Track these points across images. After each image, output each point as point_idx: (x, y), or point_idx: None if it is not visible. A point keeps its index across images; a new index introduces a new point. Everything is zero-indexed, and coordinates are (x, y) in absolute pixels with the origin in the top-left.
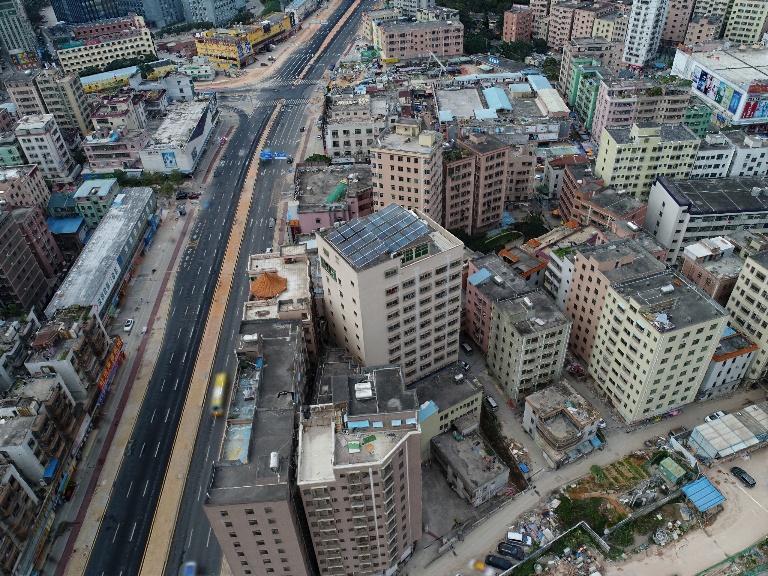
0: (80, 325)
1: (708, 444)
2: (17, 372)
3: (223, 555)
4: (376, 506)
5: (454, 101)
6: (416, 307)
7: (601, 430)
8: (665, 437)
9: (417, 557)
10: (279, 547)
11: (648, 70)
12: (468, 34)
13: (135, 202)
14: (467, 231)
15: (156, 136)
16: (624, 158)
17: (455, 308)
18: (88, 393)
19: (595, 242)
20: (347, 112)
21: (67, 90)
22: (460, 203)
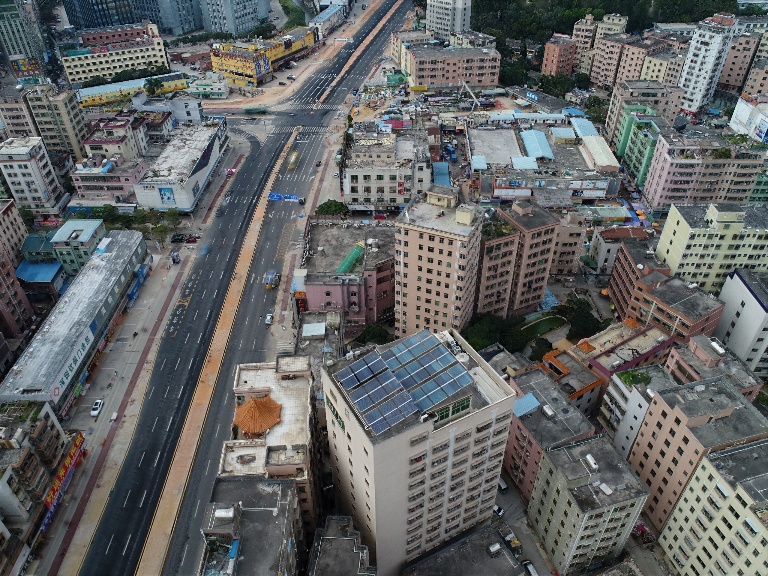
0: (27, 429)
1: None
2: None
3: None
4: None
5: (488, 143)
6: (447, 470)
7: None
8: None
9: None
10: None
11: (702, 116)
12: (504, 63)
13: (121, 250)
14: (502, 314)
15: (155, 166)
16: (697, 244)
17: (496, 464)
18: (30, 515)
19: (661, 350)
20: (369, 154)
21: (61, 109)
22: (497, 284)
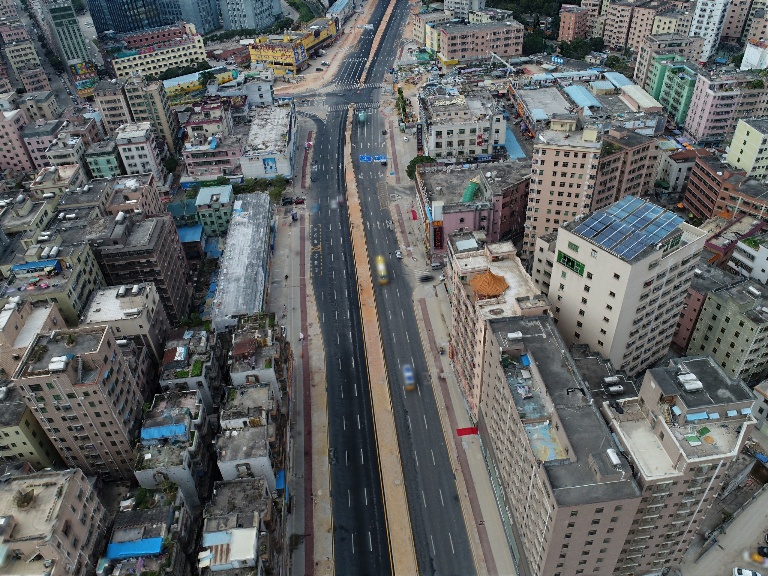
0: None
1: None
2: (212, 383)
3: (474, 560)
4: (703, 500)
5: (538, 100)
6: (658, 299)
7: None
8: None
9: None
10: (604, 547)
11: (710, 66)
12: None
13: (256, 208)
14: None
15: (250, 142)
16: (767, 148)
17: (683, 300)
18: (282, 402)
19: (756, 232)
20: (448, 112)
21: (155, 98)
22: (604, 198)
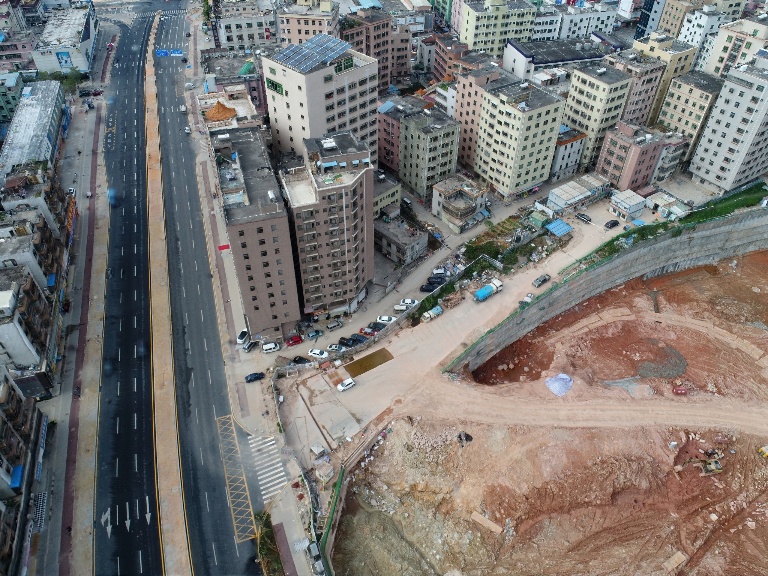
0: None
1: (560, 199)
2: None
3: (218, 324)
4: (346, 229)
5: None
6: (346, 114)
7: (488, 207)
8: (531, 205)
9: (370, 298)
10: (279, 268)
11: None
12: None
13: (45, 93)
14: None
15: (43, 39)
16: (482, 25)
17: (374, 120)
18: (60, 233)
19: None
20: (236, 8)
21: None
22: None
